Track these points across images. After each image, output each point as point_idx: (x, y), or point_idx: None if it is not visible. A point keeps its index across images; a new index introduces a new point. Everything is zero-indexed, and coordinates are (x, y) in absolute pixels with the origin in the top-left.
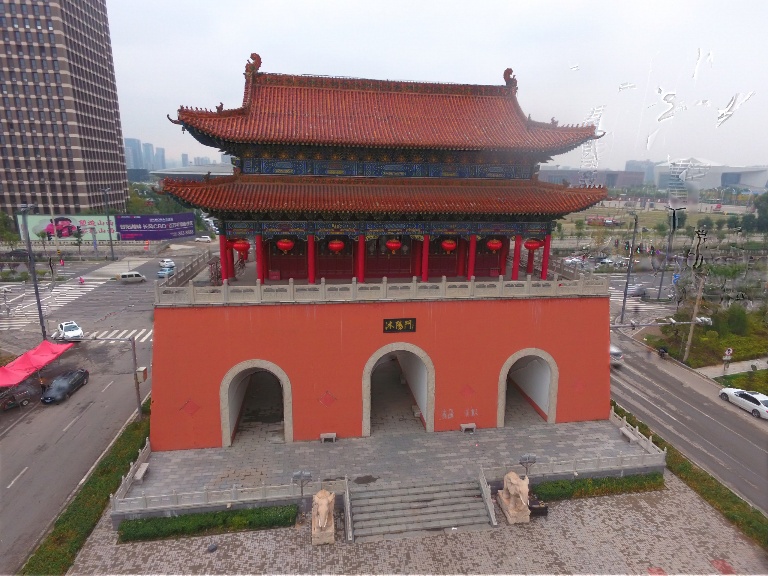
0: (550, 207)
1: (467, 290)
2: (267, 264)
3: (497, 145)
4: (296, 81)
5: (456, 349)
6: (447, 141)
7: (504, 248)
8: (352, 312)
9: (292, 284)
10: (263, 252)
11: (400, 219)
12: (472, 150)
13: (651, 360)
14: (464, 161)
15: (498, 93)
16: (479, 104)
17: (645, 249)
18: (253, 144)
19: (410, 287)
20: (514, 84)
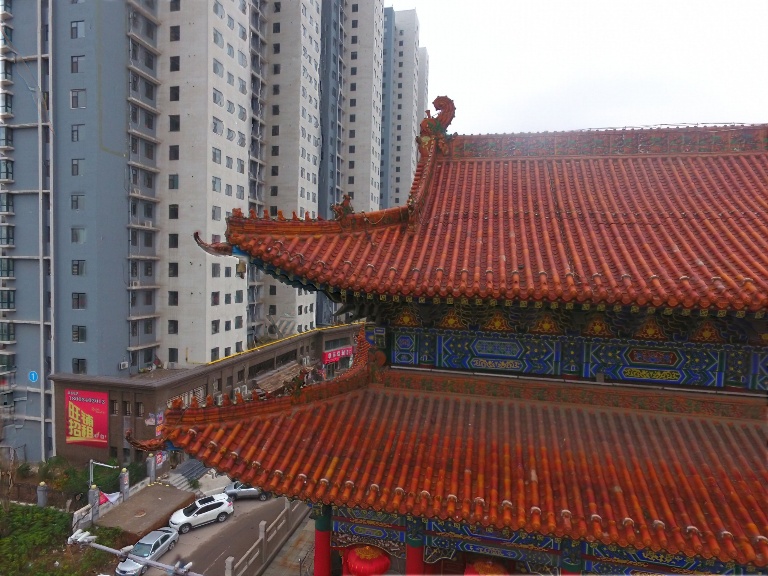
0: None
1: None
2: None
3: None
4: None
5: None
6: None
7: None
8: None
9: None
10: None
11: None
12: None
13: None
14: None
15: (466, 152)
16: None
17: None
18: None
19: None
20: None
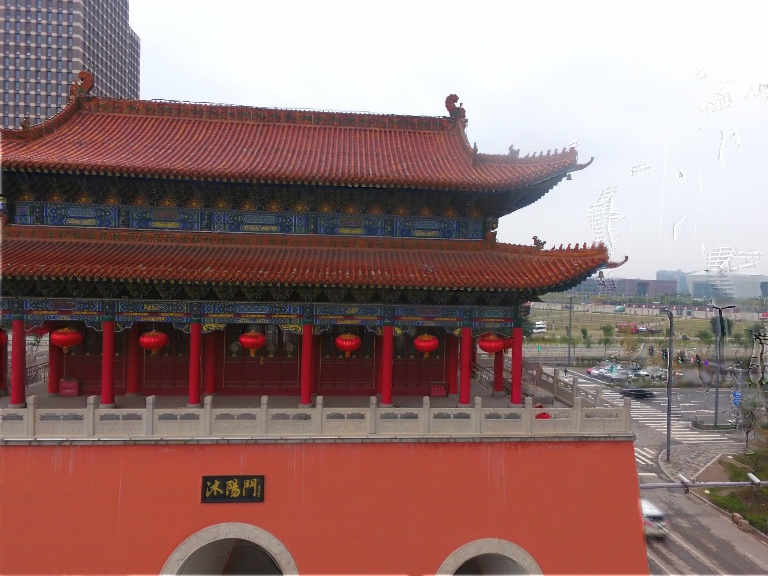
0: (510, 279)
1: (363, 423)
2: (59, 369)
3: (415, 179)
4: (142, 108)
5: (343, 538)
6: (332, 173)
7: (452, 350)
8: (142, 461)
9: (32, 406)
10: (53, 350)
11: (262, 298)
12: (382, 192)
13: (722, 532)
14: (375, 211)
15: (438, 127)
16: (408, 139)
17: (688, 358)
18: (20, 177)
19: (256, 415)
20: (461, 115)
